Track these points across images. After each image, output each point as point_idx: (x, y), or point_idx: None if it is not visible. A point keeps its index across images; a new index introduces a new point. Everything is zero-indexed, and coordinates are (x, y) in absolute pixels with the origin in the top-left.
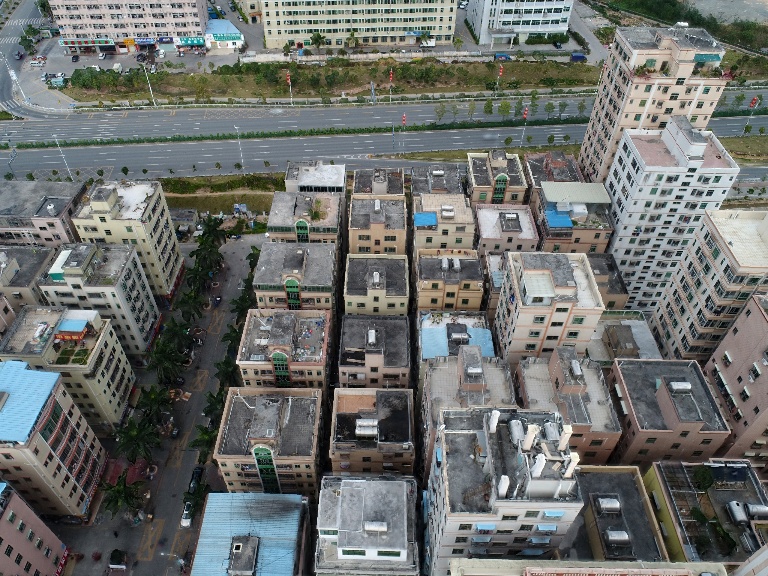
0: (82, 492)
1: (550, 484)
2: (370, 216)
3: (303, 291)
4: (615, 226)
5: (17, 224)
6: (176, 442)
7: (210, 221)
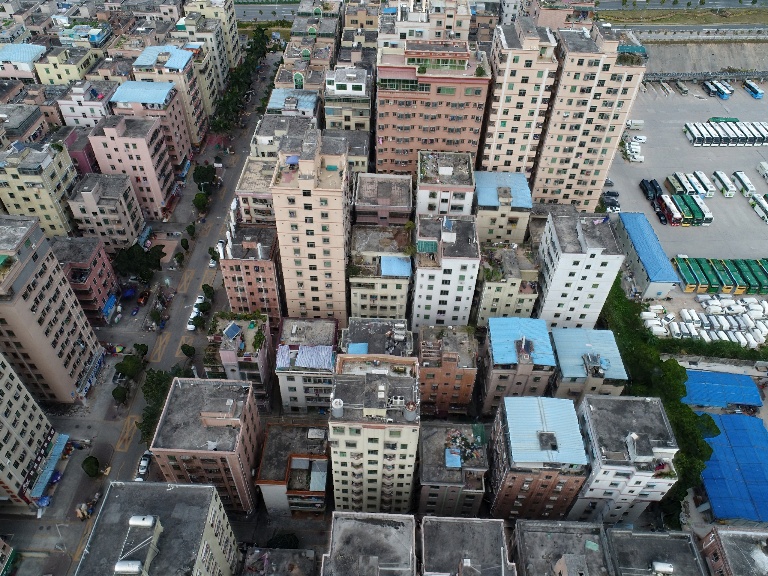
0: (198, 130)
1: (417, 15)
2: (358, 8)
3: (318, 37)
4: (501, 15)
5: (151, 10)
6: (244, 130)
7: (260, 27)
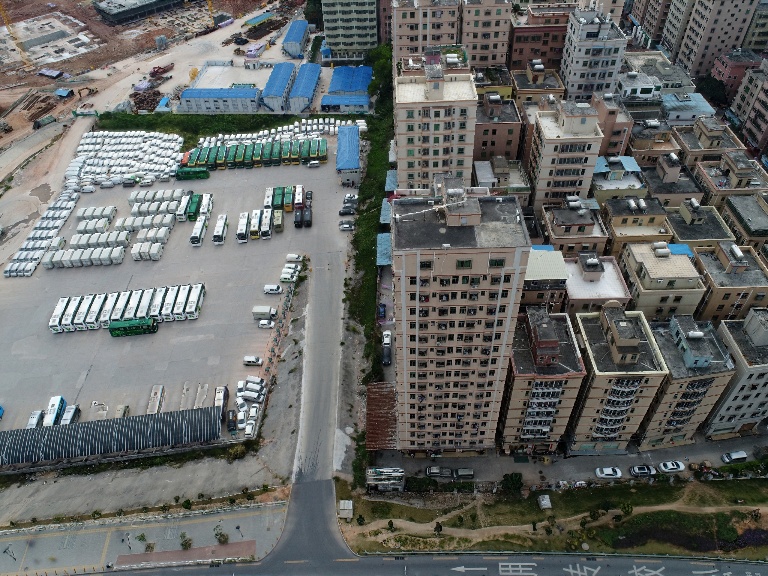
0: None
1: None
2: None
3: None
4: None
5: None
6: None
7: None
